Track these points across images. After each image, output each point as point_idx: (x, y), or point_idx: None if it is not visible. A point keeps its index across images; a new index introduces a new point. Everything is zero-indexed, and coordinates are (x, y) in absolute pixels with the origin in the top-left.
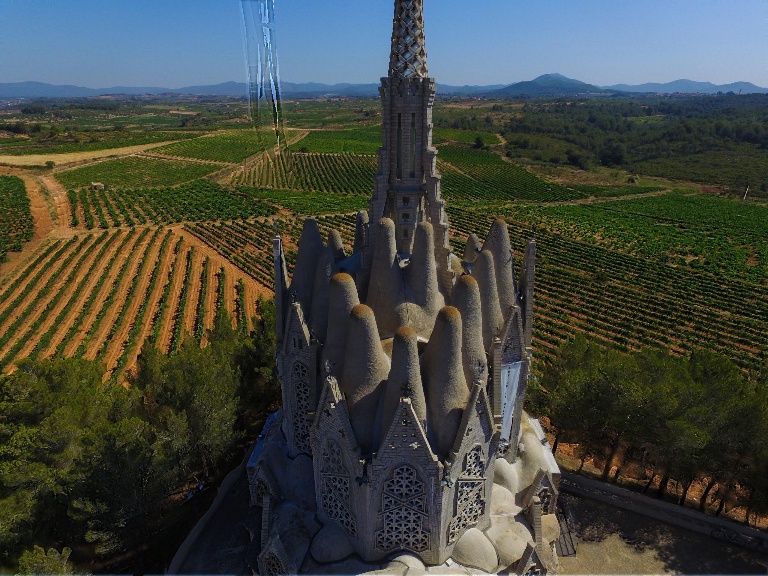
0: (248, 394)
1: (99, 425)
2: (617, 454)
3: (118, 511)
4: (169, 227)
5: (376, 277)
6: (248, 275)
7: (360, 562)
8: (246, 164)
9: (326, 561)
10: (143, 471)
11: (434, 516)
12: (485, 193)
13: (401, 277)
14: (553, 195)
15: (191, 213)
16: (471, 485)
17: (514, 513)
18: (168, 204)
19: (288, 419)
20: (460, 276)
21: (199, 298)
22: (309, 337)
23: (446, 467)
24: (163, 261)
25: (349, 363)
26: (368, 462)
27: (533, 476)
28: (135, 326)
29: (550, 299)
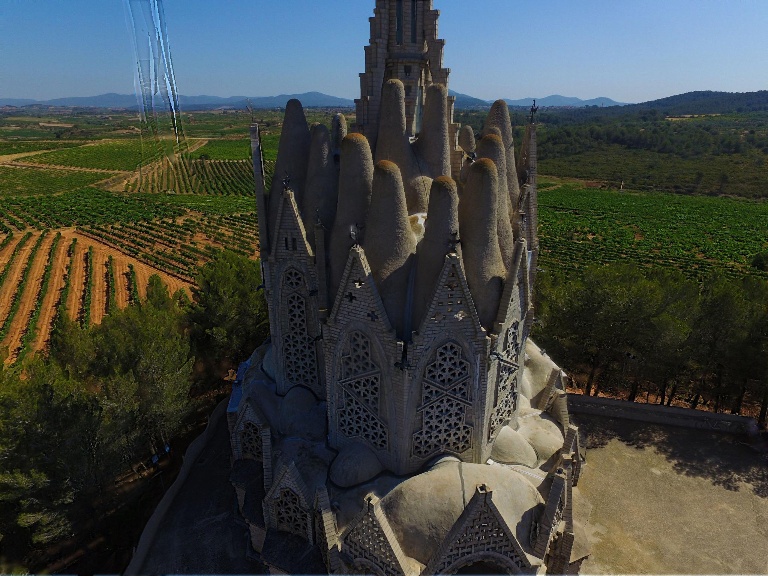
0: (199, 362)
1: (22, 385)
2: (598, 370)
3: (63, 481)
4: (57, 231)
5: (385, 150)
6: (162, 272)
7: (394, 478)
8: (142, 169)
9: (353, 484)
10: (90, 434)
11: (478, 405)
12: None
13: (412, 151)
14: None
15: (82, 218)
16: (508, 371)
17: (538, 412)
18: (51, 211)
19: (277, 346)
20: (465, 161)
21: (106, 298)
22: (305, 234)
23: (493, 340)
24: (54, 264)
25: (374, 233)
26: (407, 343)
27: (544, 380)
28: (28, 330)
29: None
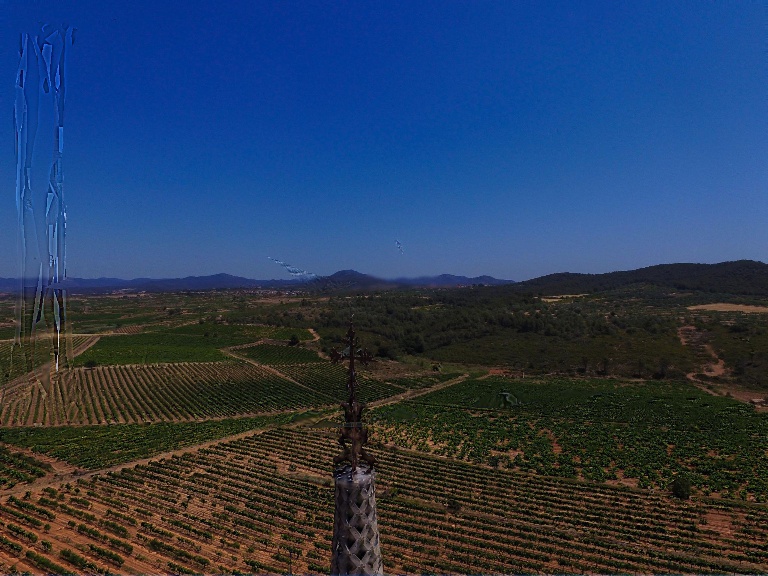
0: None
1: None
2: None
3: None
4: None
5: None
6: None
7: None
8: (4, 398)
9: None
10: None
11: None
12: (310, 399)
13: None
14: (375, 393)
15: None
16: None
17: None
18: None
19: None
20: None
21: None
22: None
23: None
24: None
25: None
26: None
27: None
28: None
29: (415, 553)
